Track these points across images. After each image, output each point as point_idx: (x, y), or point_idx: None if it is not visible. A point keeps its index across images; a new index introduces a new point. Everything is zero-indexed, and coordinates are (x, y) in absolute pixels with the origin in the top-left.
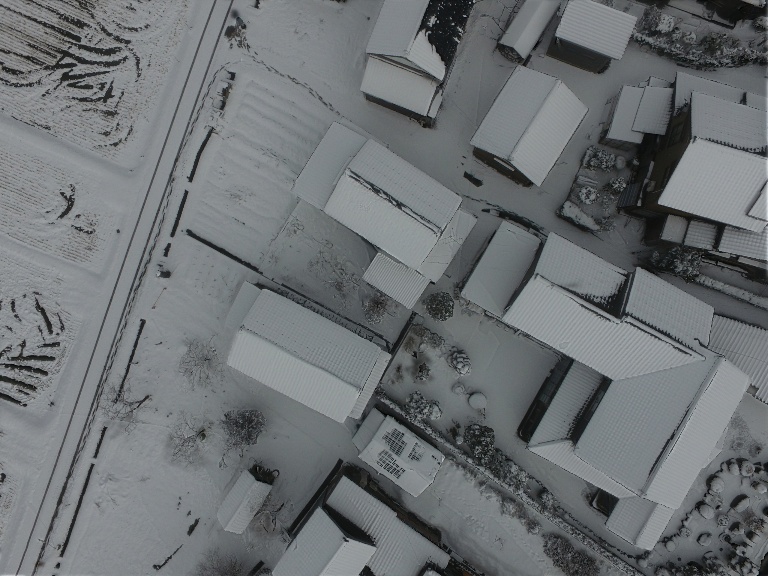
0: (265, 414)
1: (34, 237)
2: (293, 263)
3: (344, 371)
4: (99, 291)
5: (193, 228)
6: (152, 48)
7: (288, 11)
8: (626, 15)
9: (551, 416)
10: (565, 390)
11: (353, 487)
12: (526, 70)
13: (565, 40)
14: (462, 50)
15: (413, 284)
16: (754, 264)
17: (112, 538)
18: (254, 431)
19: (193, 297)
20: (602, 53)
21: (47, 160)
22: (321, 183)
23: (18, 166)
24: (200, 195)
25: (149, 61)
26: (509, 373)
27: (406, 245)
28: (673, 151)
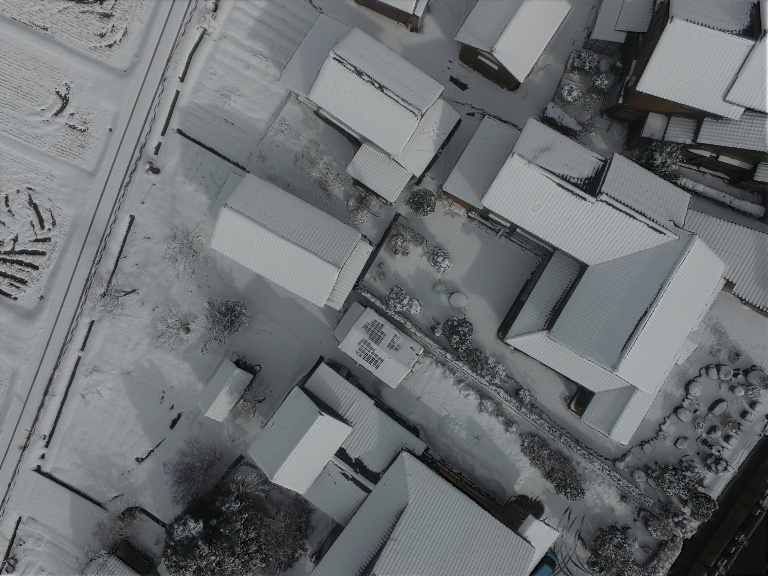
0: (249, 310)
1: (29, 133)
2: (280, 162)
3: (324, 251)
4: (90, 187)
5: (183, 127)
6: None
7: None
8: None
9: (529, 308)
10: (543, 283)
11: (332, 373)
12: None
13: None
14: None
15: (396, 177)
16: (734, 163)
17: (96, 430)
18: (237, 320)
19: (181, 194)
20: None
21: (44, 59)
22: (307, 72)
23: (15, 65)
24: (191, 95)
25: None
26: (490, 274)
27: (388, 130)
28: (653, 43)
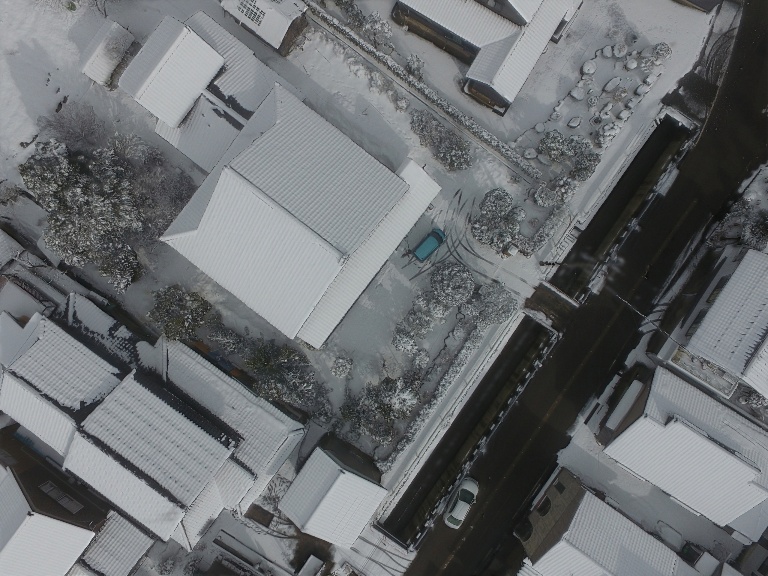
0: None
1: None
2: None
3: None
4: None
5: None
6: None
7: None
8: None
9: None
10: None
11: (210, 21)
12: None
13: None
14: None
15: None
16: None
17: None
18: None
19: None
20: None
21: None
22: None
23: None
24: None
25: None
26: None
27: None
28: None
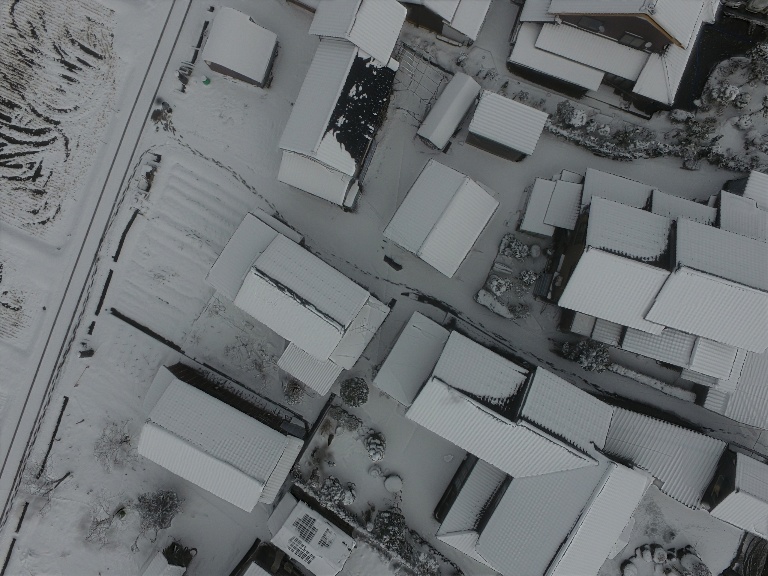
0: (184, 493)
1: None
2: (214, 343)
3: (249, 464)
4: (24, 368)
5: (117, 307)
6: (81, 129)
7: (213, 96)
8: (537, 111)
9: (459, 506)
10: (473, 480)
11: (262, 574)
12: (438, 165)
13: (478, 135)
14: (383, 137)
15: (326, 372)
16: None
17: None
18: (168, 514)
19: (115, 376)
20: (513, 148)
21: None
22: (233, 275)
23: None
24: (125, 274)
25: (78, 142)
26: (426, 456)
27: (313, 340)
28: (577, 250)
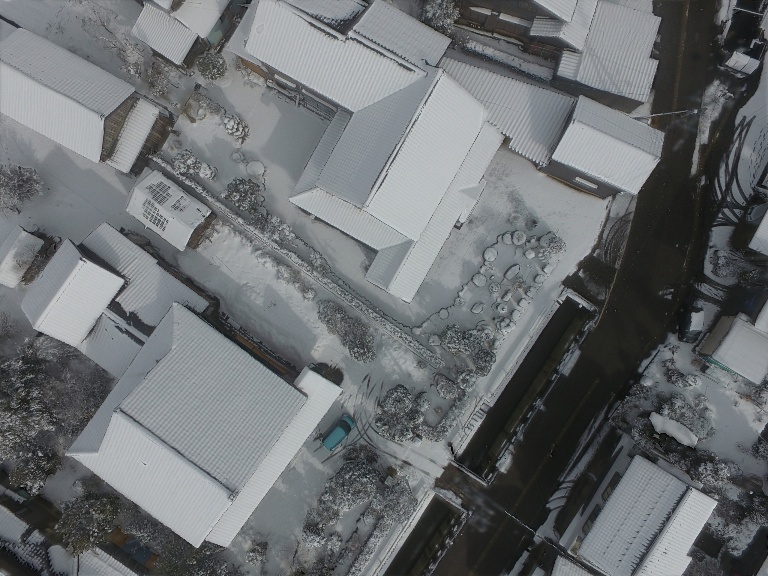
0: (48, 181)
1: None
2: (79, 34)
3: (90, 100)
4: None
5: None
6: None
7: None
8: None
9: (311, 166)
10: (324, 140)
11: (113, 232)
12: None
13: None
14: None
15: (180, 38)
16: (514, 20)
17: None
18: (25, 185)
19: None
20: None
21: None
22: None
23: None
24: None
25: None
26: (289, 144)
27: None
28: None
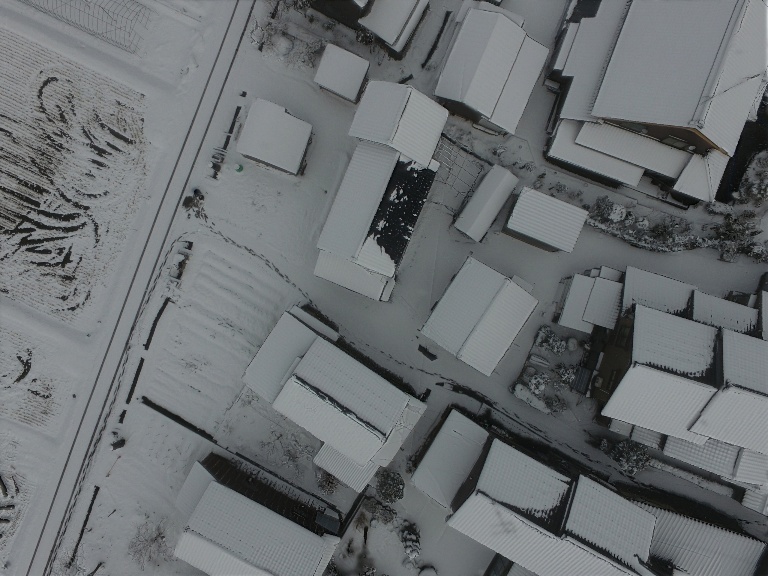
0: None
1: None
2: (247, 433)
3: (288, 572)
4: (54, 457)
5: (149, 395)
6: (111, 215)
7: (246, 183)
8: (577, 209)
9: None
10: None
11: None
12: (477, 263)
13: (517, 231)
14: (418, 226)
15: (363, 469)
16: None
17: None
18: None
19: (147, 466)
20: (553, 245)
21: (4, 325)
22: (271, 375)
23: None
24: (156, 362)
25: (108, 227)
26: (460, 547)
27: (352, 445)
28: (619, 355)
